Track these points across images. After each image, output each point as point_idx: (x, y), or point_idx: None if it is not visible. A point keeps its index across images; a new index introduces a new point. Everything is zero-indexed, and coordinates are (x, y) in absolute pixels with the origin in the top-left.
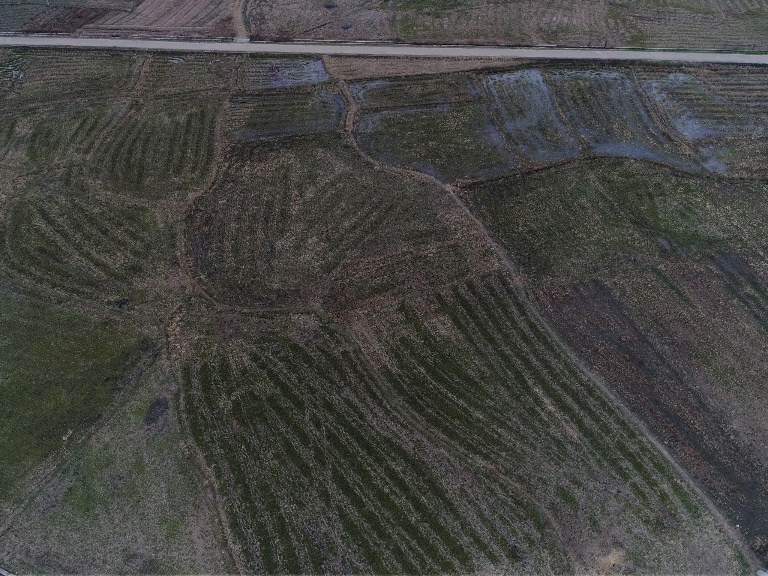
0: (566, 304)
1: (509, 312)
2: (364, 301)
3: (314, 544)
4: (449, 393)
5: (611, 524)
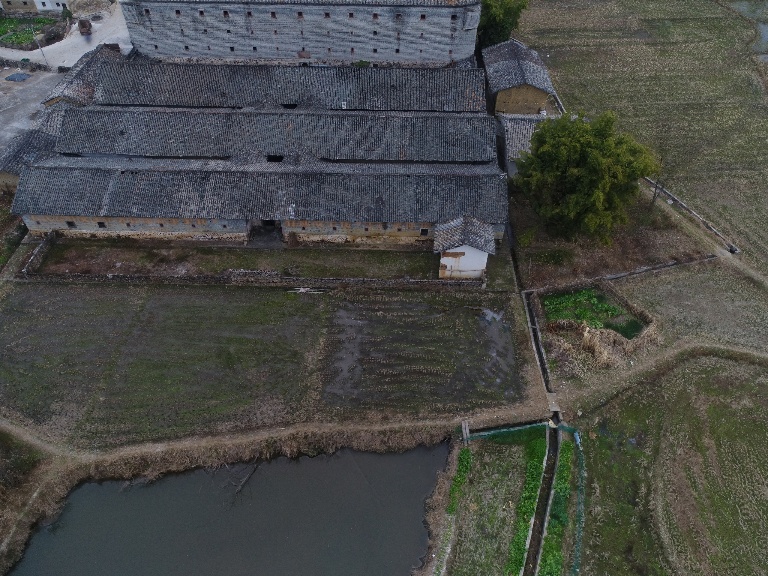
0: None
1: None
2: None
3: None
4: None
5: None
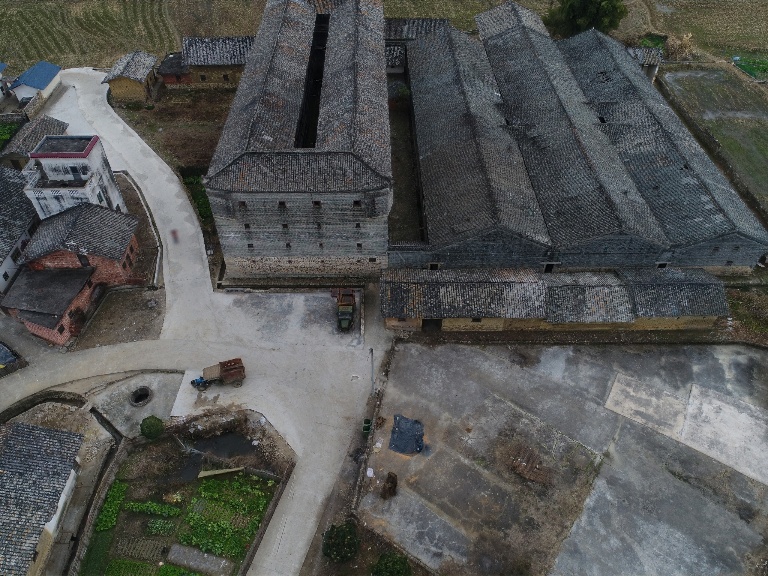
0: (186, 6)
1: (153, 6)
2: (86, 1)
3: (7, 48)
4: (100, 23)
5: (133, 50)
